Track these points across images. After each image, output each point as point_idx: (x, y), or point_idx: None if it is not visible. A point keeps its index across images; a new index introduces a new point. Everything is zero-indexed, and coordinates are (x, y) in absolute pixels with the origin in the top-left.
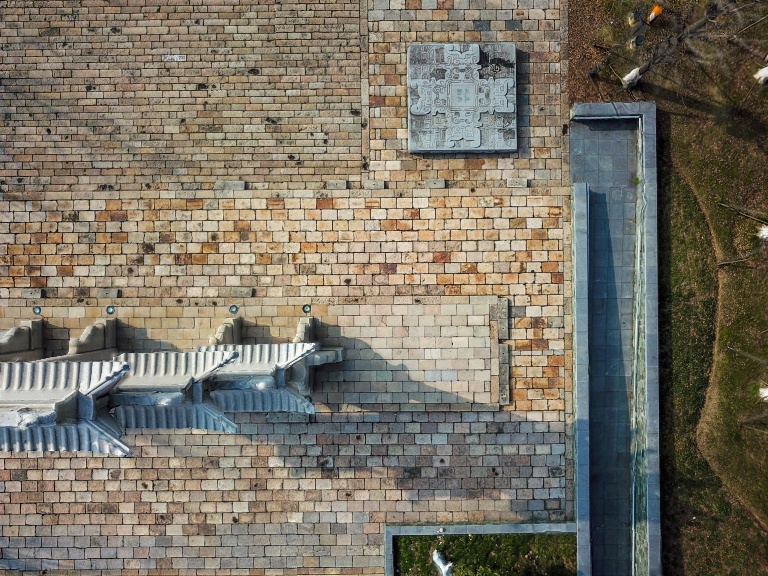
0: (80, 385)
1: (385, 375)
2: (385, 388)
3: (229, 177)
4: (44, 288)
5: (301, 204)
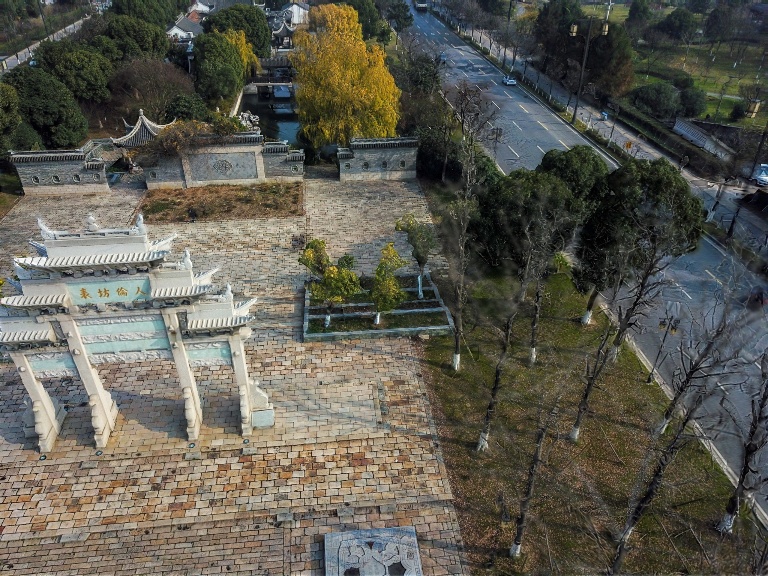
0: (46, 259)
1: (3, 426)
2: (7, 419)
3: (73, 545)
4: (241, 456)
5: (17, 528)
